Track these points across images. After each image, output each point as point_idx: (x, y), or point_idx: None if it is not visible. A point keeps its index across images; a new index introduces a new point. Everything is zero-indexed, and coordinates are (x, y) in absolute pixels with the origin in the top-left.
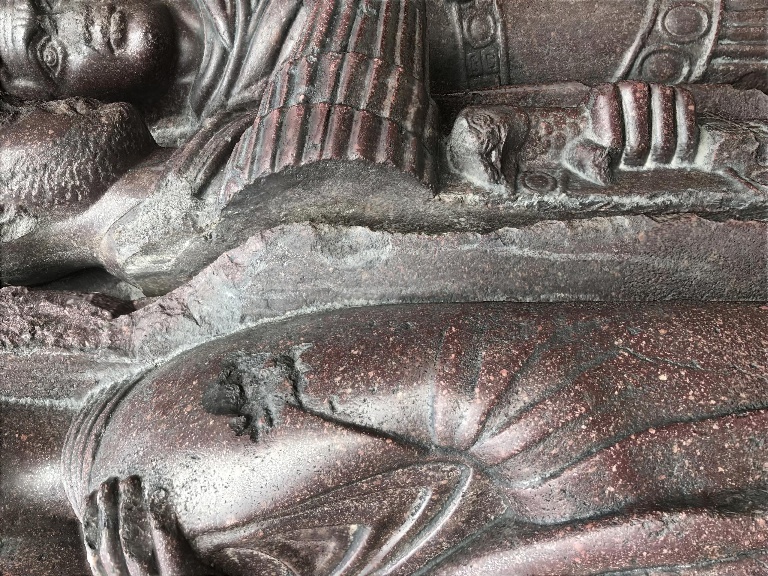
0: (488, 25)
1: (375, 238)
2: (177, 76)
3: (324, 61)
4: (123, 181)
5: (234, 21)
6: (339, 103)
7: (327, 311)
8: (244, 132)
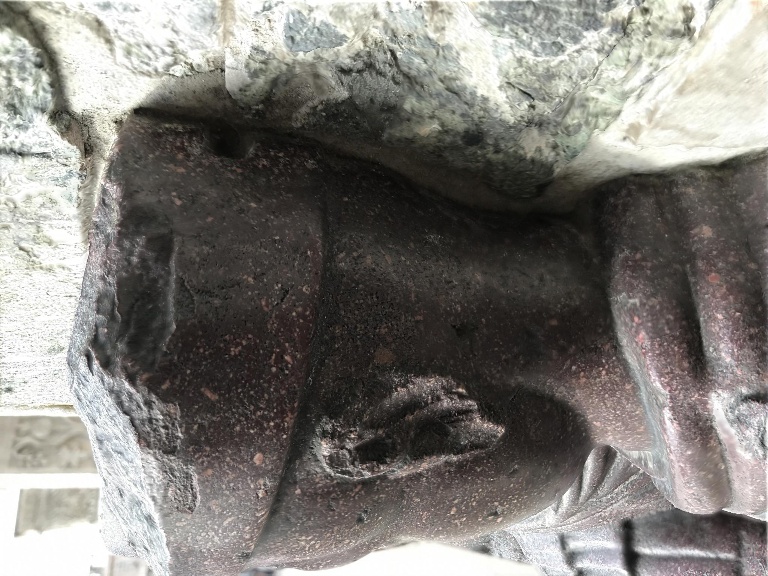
0: None
1: None
2: None
3: None
4: None
5: None
6: None
7: None
8: None
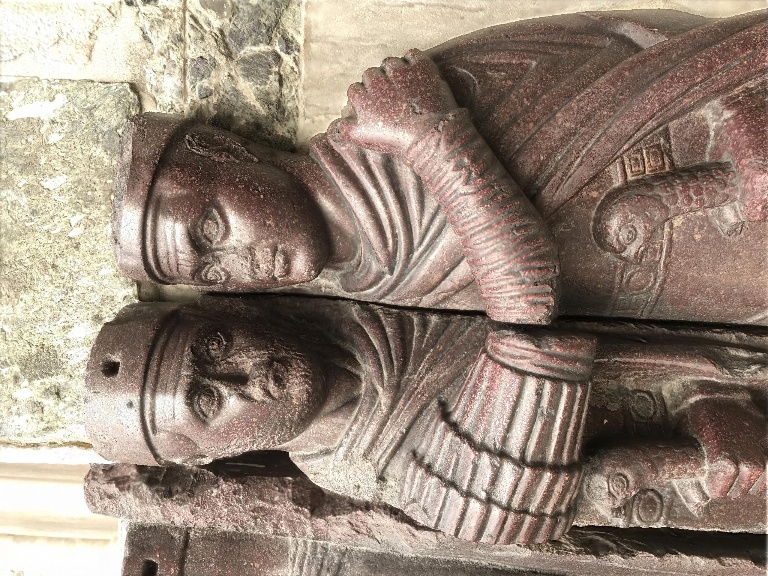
0: (648, 280)
1: (520, 550)
2: (328, 263)
3: (505, 468)
4: (310, 430)
5: (395, 256)
6: (514, 509)
7: (476, 569)
8: (429, 480)
